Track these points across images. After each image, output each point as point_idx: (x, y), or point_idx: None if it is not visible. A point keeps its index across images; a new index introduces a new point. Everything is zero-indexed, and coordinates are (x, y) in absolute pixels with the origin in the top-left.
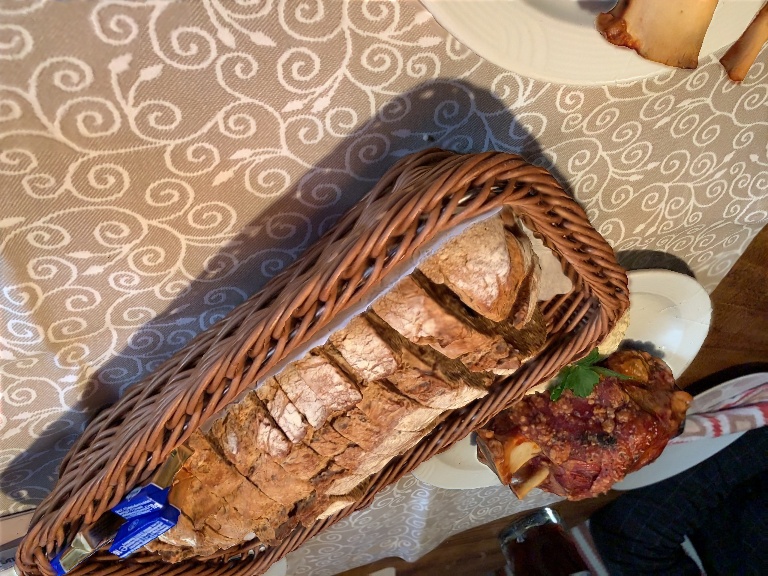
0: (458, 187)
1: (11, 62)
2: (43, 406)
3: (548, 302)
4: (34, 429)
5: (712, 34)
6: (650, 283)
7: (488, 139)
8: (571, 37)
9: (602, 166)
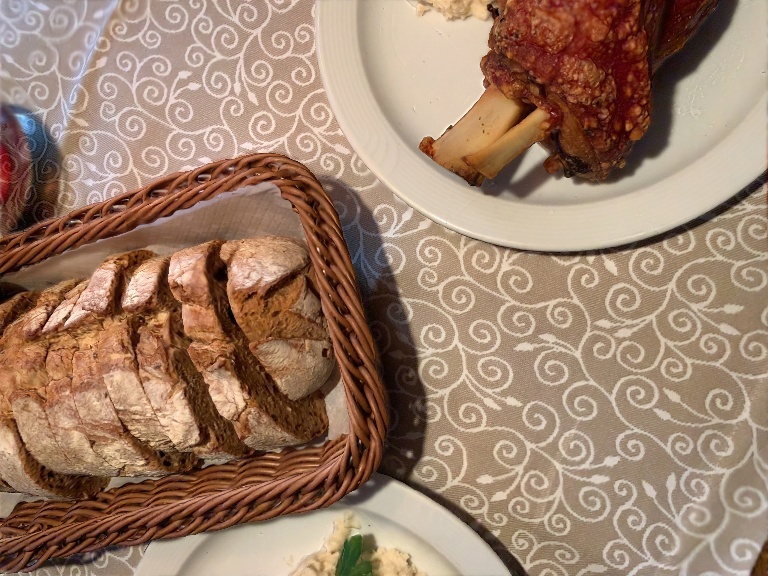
0: (262, 164)
1: (145, 48)
2: None
3: (332, 443)
4: None
5: (540, 230)
6: (471, 558)
7: (359, 254)
8: (418, 168)
9: (456, 360)
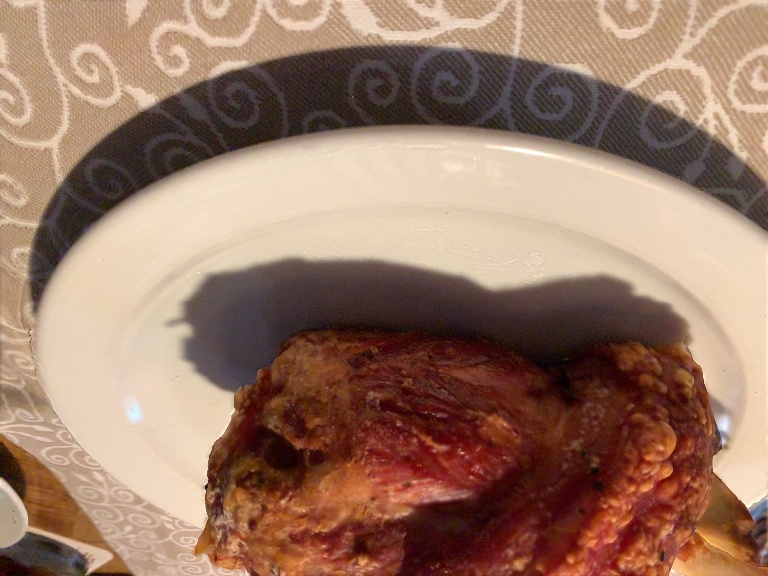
0: None
1: None
2: None
3: None
4: None
5: None
6: None
7: None
8: None
9: None
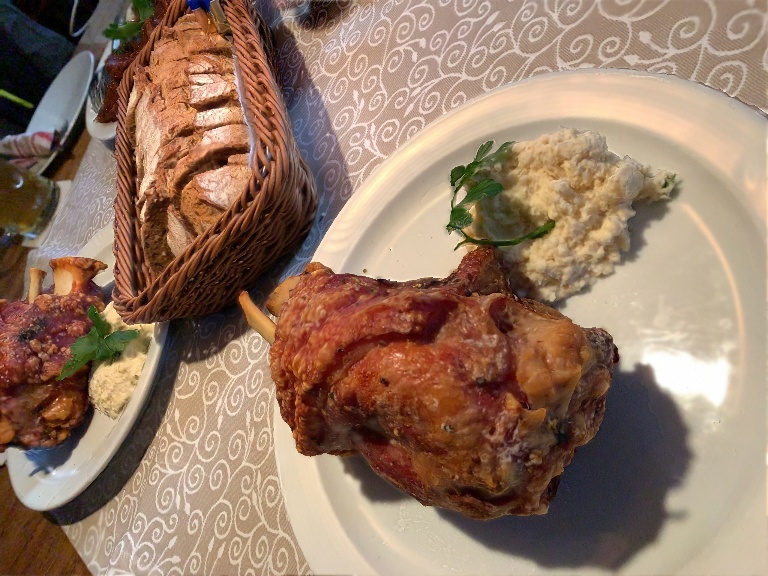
0: None
1: None
2: (291, 9)
3: None
4: (282, 4)
5: None
6: None
7: (303, 260)
8: None
9: (243, 367)
